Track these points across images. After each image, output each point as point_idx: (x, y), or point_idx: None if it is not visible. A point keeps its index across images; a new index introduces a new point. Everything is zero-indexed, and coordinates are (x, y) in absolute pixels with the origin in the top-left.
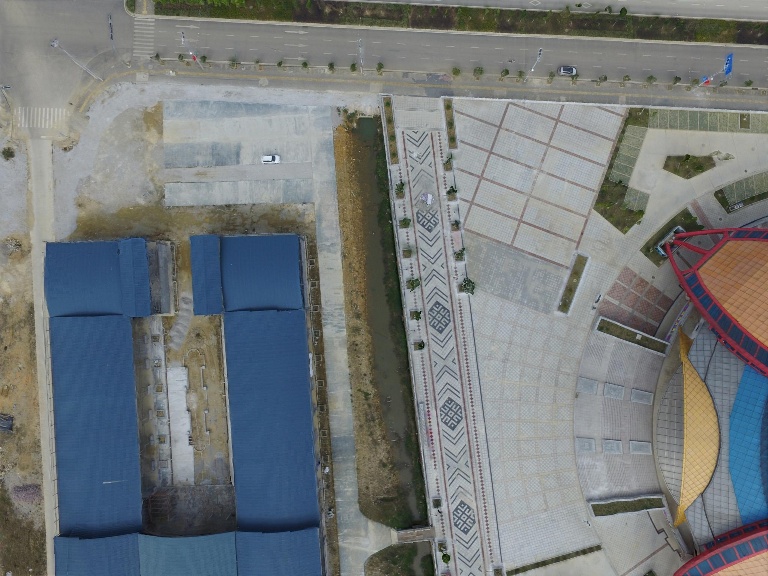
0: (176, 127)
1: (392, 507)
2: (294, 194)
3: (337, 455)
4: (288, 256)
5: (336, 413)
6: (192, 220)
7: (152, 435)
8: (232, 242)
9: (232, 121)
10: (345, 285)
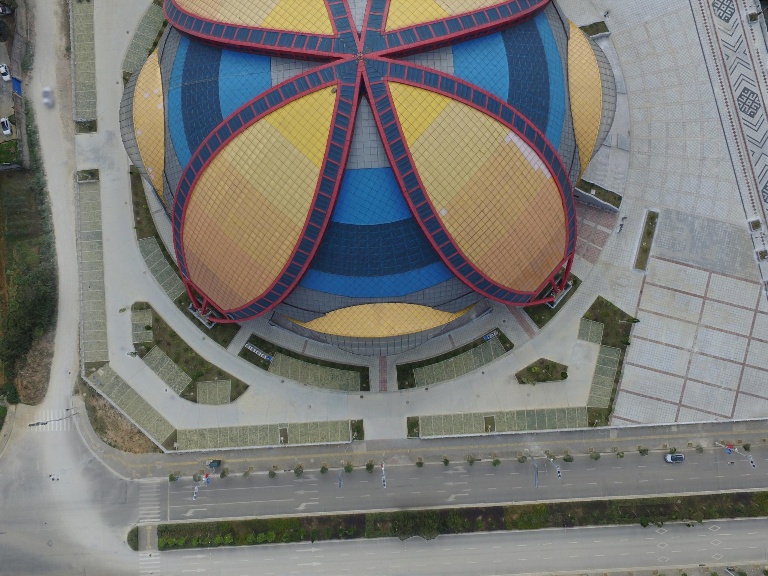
0: None
1: None
2: None
3: None
4: None
5: None
6: None
7: None
8: None
9: None
10: None
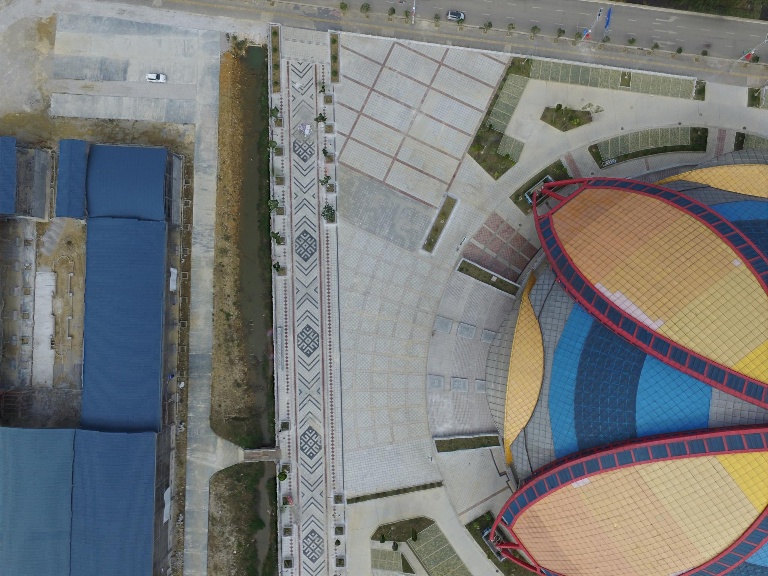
0: (68, 39)
1: (242, 427)
2: (176, 114)
3: (193, 371)
4: (154, 168)
5: (197, 330)
6: (75, 131)
7: (15, 335)
8: (102, 150)
9: (123, 38)
10: (218, 207)
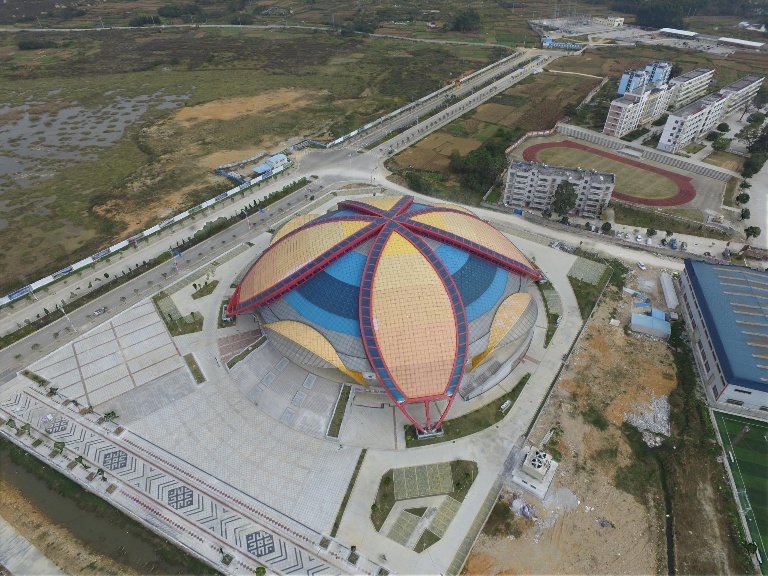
0: None
1: None
2: None
3: None
4: None
5: None
6: None
7: None
8: None
9: None
10: (9, 520)
